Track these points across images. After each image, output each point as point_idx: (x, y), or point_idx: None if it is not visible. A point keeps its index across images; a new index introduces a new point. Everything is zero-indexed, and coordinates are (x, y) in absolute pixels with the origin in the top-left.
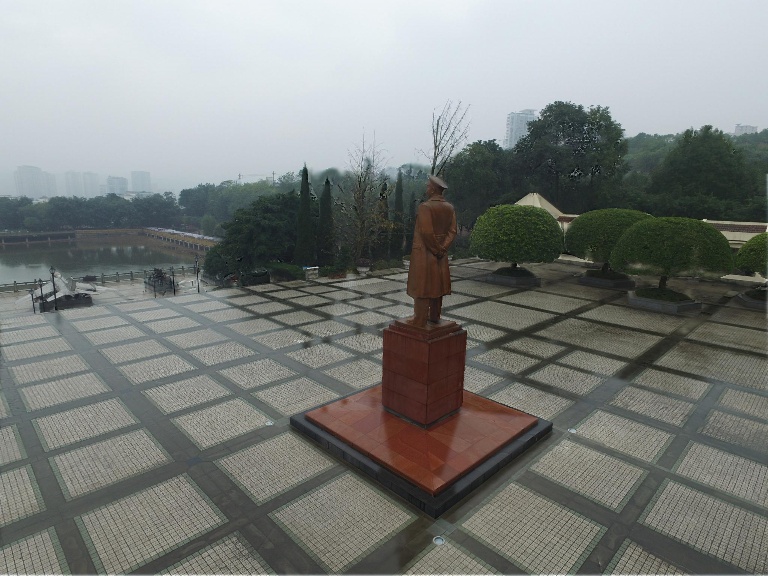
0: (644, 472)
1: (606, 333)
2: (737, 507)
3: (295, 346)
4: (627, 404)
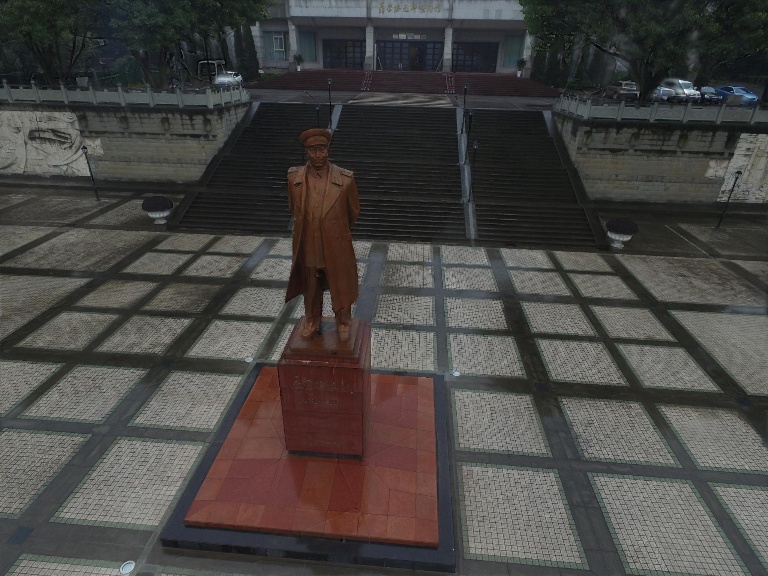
0: (291, 325)
1: None
2: (301, 299)
3: None
4: (157, 344)
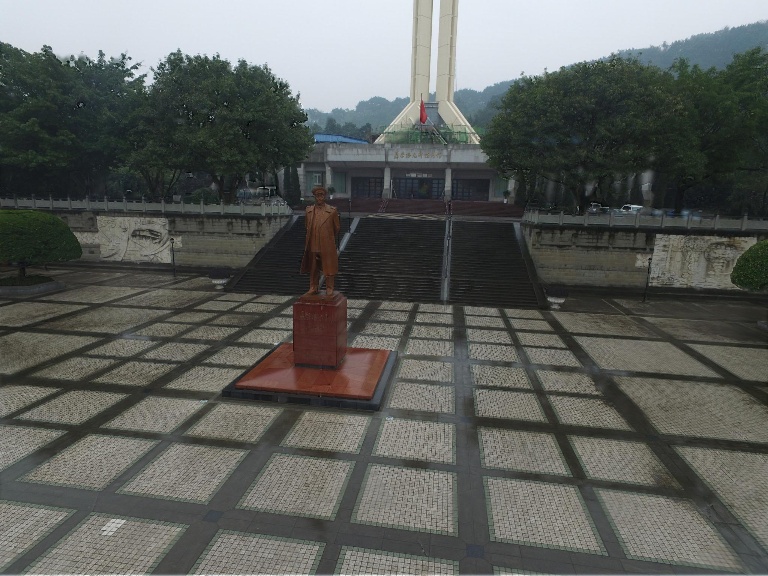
0: None
1: (2, 348)
2: None
3: (154, 512)
4: (218, 336)
